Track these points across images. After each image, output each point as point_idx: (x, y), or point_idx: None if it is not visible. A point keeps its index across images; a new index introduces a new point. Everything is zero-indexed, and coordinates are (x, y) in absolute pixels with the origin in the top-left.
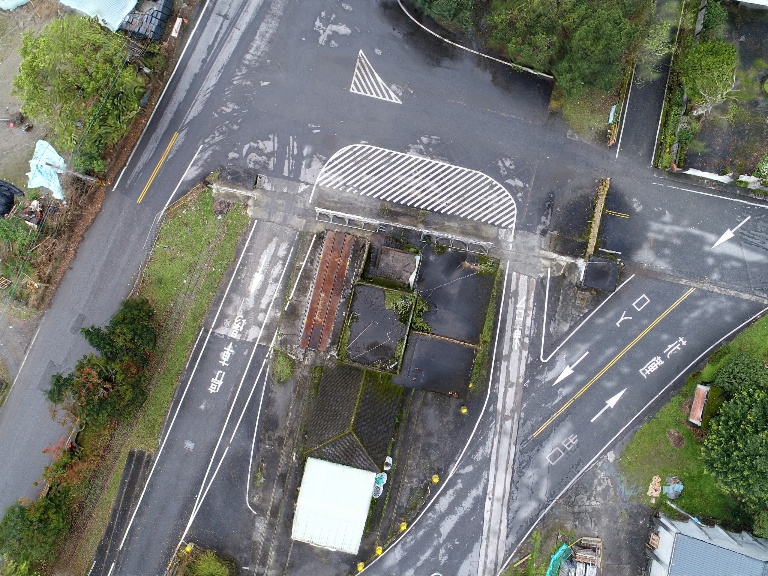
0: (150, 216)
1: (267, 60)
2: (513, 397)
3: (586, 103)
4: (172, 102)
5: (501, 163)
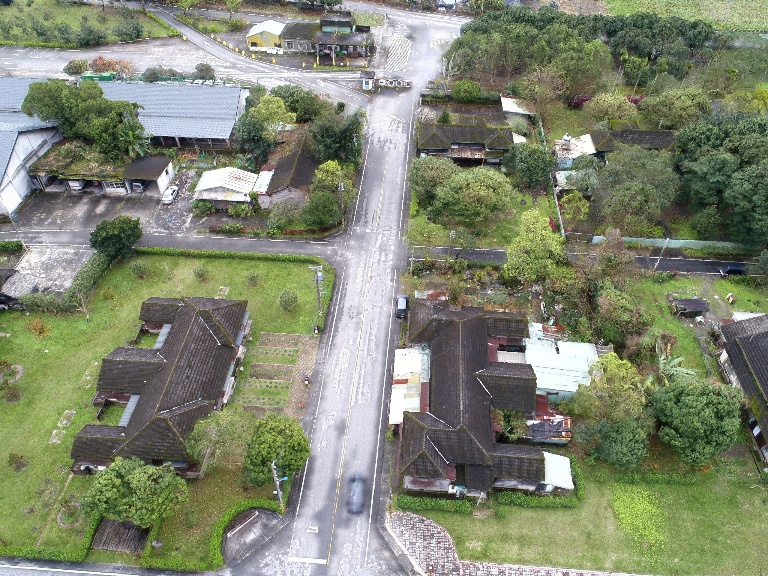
0: (373, 10)
1: None
2: None
3: None
4: None
5: (412, 67)
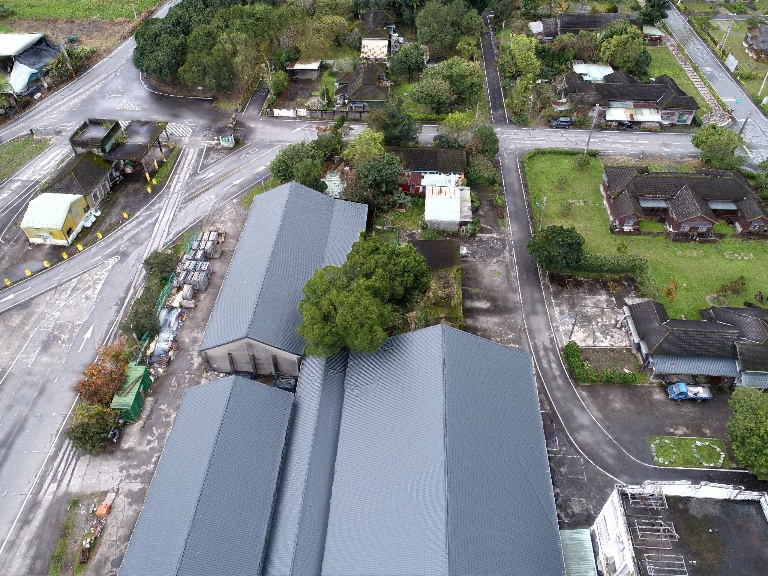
0: None
1: (78, 104)
2: (180, 186)
3: (229, 103)
4: (26, 116)
5: (186, 120)
